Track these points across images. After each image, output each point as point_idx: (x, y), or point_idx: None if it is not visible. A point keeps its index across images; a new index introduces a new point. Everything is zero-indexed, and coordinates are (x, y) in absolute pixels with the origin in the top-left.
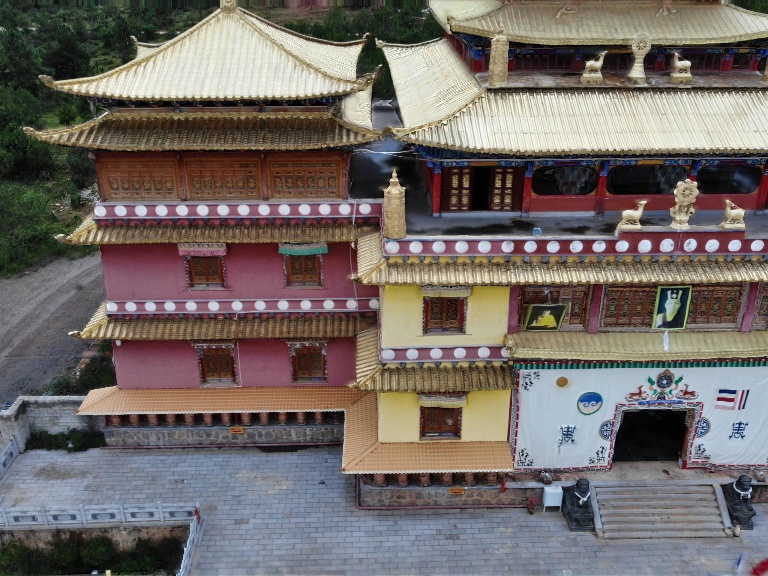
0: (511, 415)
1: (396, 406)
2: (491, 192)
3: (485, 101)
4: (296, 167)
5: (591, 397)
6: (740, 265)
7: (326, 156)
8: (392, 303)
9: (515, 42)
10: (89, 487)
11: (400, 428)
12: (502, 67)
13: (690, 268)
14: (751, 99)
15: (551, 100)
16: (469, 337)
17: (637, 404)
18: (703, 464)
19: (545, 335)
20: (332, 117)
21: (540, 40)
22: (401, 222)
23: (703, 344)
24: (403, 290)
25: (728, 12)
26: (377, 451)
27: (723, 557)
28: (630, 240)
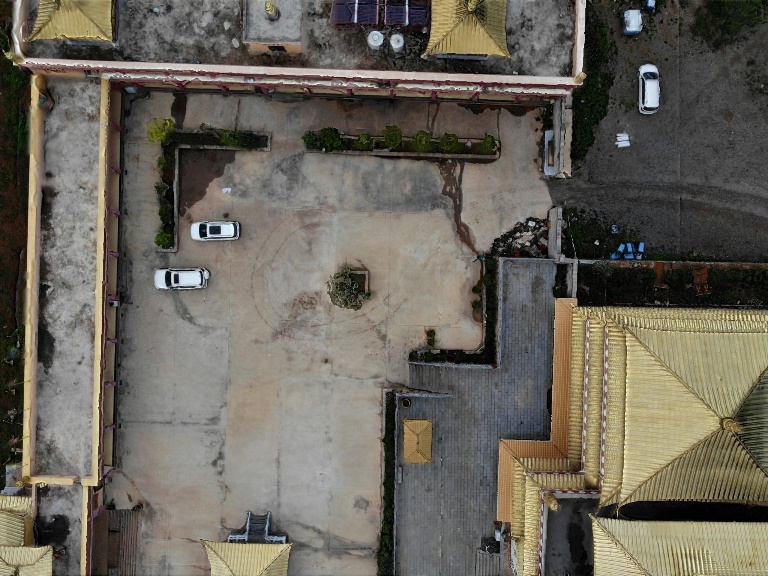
0: None
1: None
2: None
3: None
4: None
5: None
6: None
7: None
8: None
9: None
10: (525, 307)
11: None
12: None
13: None
14: None
15: None
16: None
17: None
18: None
19: None
20: None
21: None
22: None
23: None
24: None
25: None
26: None
27: None
28: None
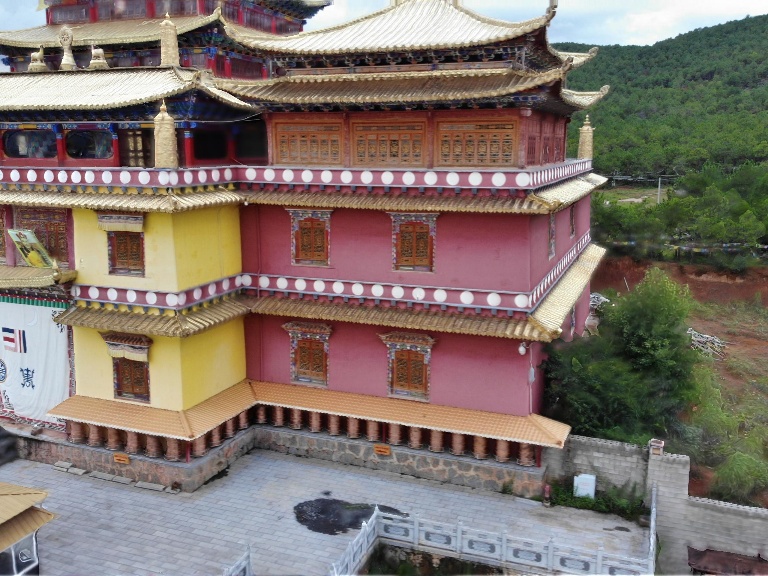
0: None
1: None
2: None
3: None
4: None
5: None
6: None
7: None
8: None
9: (23, 49)
10: None
11: None
12: None
13: None
14: (129, 76)
15: None
16: None
17: None
18: (10, 414)
19: None
20: None
21: (28, 44)
22: None
23: None
24: None
25: (192, 19)
26: None
27: None
28: None
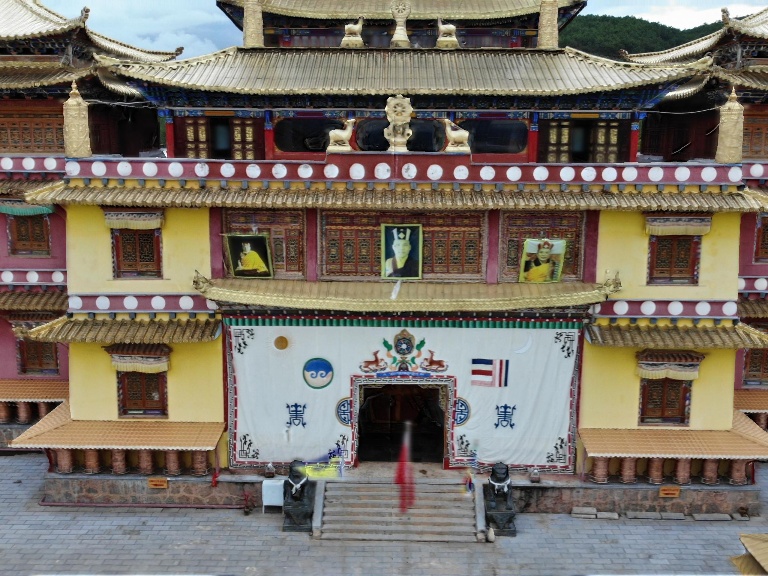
0: (228, 389)
1: (88, 371)
2: (231, 148)
3: (231, 58)
4: (22, 118)
5: (318, 365)
6: (467, 194)
7: (52, 105)
8: (76, 237)
9: (286, 19)
10: None
11: (95, 401)
12: (254, 28)
13: (408, 195)
14: (516, 58)
15: (301, 57)
16: (167, 283)
17: (375, 376)
18: (469, 463)
19: (256, 282)
20: (63, 66)
21: (307, 13)
22: (81, 139)
23: (439, 294)
24: (86, 220)
25: None
26: (63, 427)
27: (461, 561)
28: (339, 164)
